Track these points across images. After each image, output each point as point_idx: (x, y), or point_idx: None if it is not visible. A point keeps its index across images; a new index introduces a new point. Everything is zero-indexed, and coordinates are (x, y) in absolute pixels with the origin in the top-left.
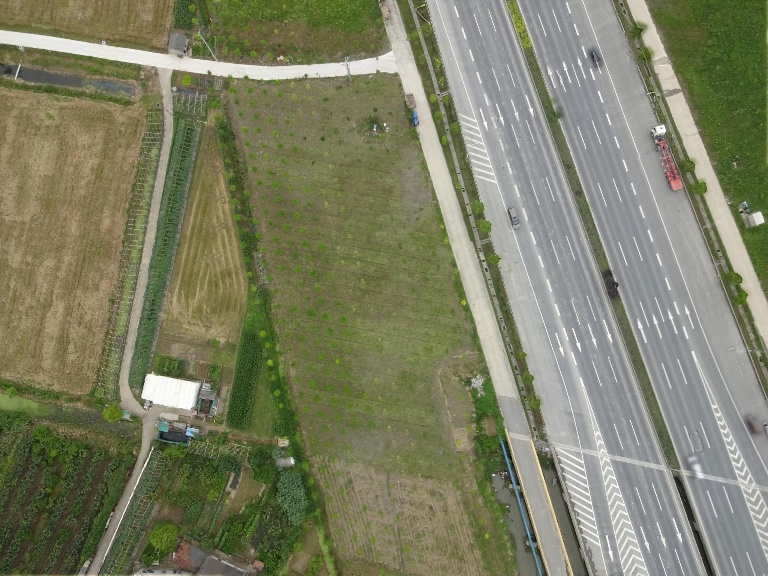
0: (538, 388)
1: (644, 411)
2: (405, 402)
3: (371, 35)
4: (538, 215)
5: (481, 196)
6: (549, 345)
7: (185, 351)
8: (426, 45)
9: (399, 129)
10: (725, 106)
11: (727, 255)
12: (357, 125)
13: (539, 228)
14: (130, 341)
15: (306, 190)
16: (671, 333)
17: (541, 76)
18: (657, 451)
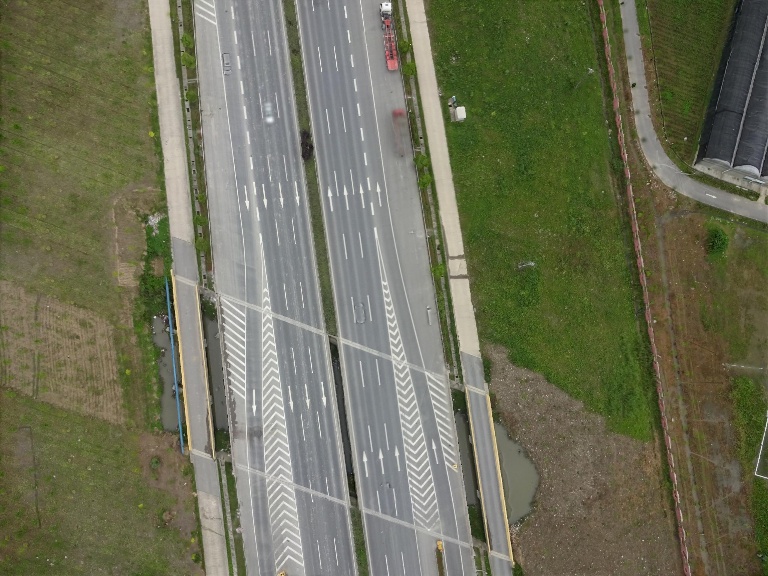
0: (215, 236)
1: (316, 276)
2: (71, 226)
3: None
4: (252, 66)
5: (197, 34)
6: (236, 196)
7: None
8: None
9: None
10: (455, 1)
11: (428, 143)
12: None
13: (250, 79)
14: None
15: None
16: (358, 207)
17: None
18: (320, 316)
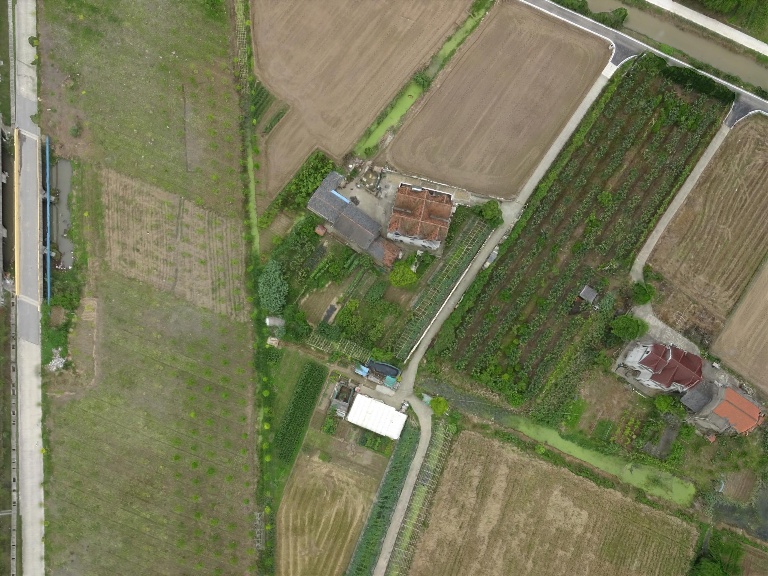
0: None
1: None
2: (137, 358)
3: None
4: None
5: None
6: None
7: (357, 455)
8: None
9: None
10: None
11: None
12: None
13: None
14: (413, 477)
15: None
16: None
17: None
18: None
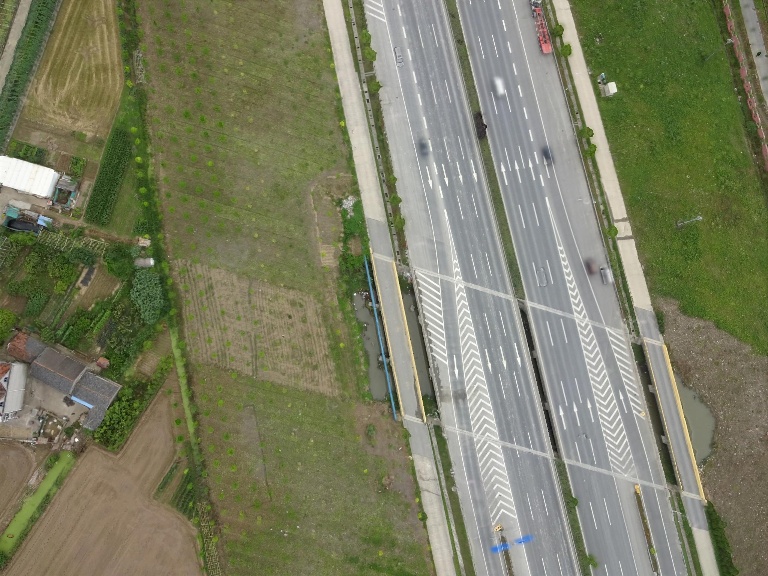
0: (405, 215)
1: (499, 245)
2: (275, 214)
3: None
4: (421, 57)
5: (370, 32)
6: (419, 177)
7: (46, 140)
8: None
9: None
10: None
11: (584, 118)
12: None
13: (421, 69)
14: None
15: None
16: (529, 179)
17: None
18: (507, 282)
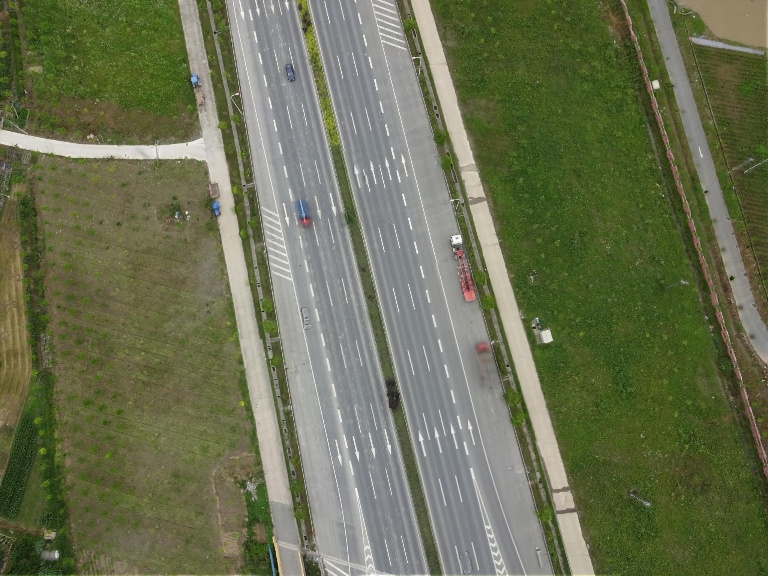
0: (312, 496)
1: (416, 527)
2: (176, 502)
3: (183, 120)
4: (330, 317)
5: (275, 293)
6: (328, 452)
7: None
8: (237, 134)
9: (200, 218)
10: (526, 219)
11: (516, 371)
12: (158, 211)
13: (330, 330)
14: None
15: (99, 274)
16: (451, 448)
17: (345, 175)
18: (425, 570)
